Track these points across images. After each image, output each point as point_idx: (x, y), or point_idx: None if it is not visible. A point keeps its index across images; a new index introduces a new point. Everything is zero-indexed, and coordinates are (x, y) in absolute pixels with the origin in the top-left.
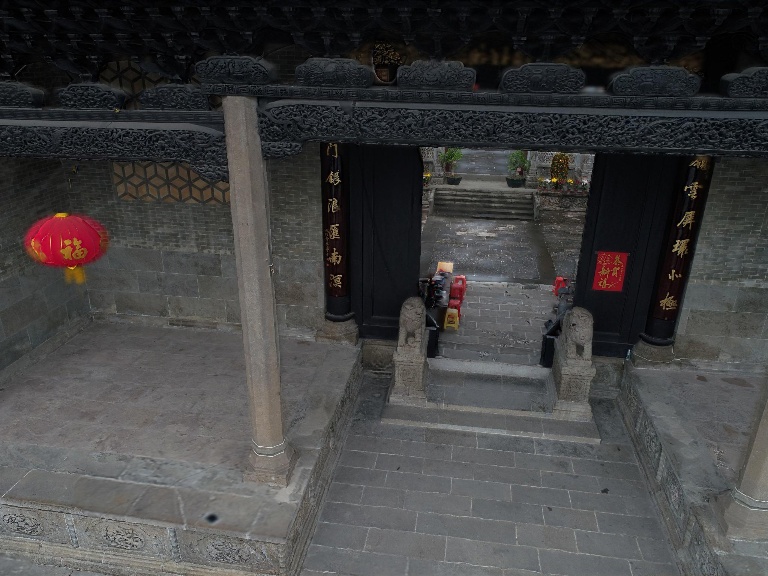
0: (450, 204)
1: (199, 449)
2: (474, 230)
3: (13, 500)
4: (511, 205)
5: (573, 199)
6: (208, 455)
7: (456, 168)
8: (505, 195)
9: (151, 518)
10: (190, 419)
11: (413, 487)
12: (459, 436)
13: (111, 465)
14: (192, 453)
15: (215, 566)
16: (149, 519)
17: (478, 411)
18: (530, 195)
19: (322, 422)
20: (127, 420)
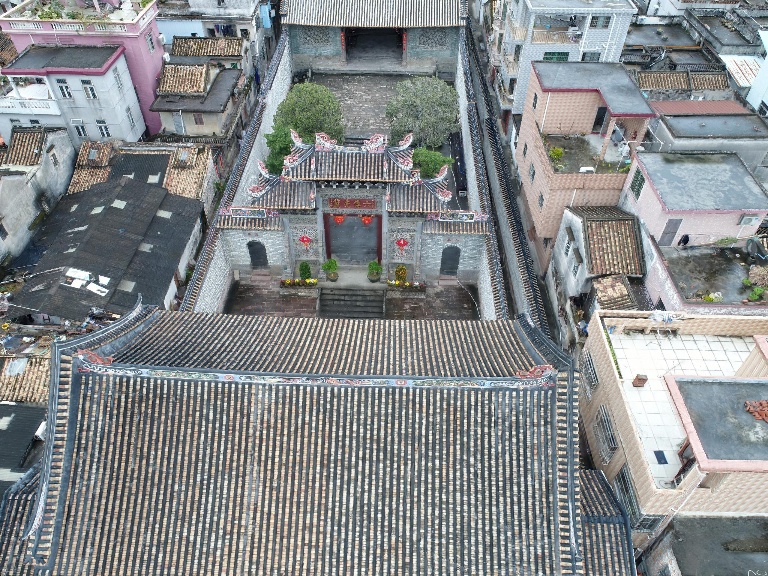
0: (330, 305)
1: None
2: None
3: None
4: (369, 303)
5: (410, 292)
6: None
7: (341, 225)
8: (366, 293)
9: None
10: None
11: None
12: None
13: None
14: None
15: None
16: None
17: None
18: (382, 292)
19: None
20: None
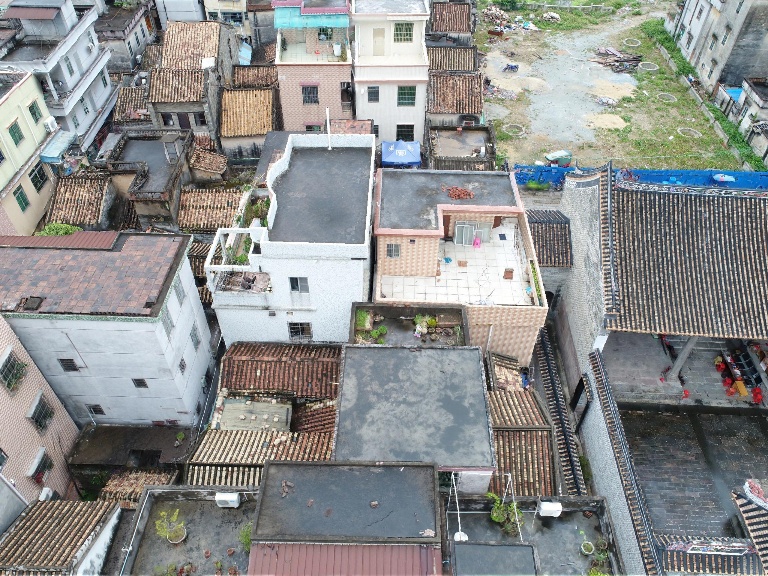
0: None
1: None
2: (767, 492)
3: None
4: None
5: None
6: None
7: None
8: None
9: None
10: None
11: None
12: None
13: None
14: None
15: None
16: None
17: None
18: None
19: None
20: None
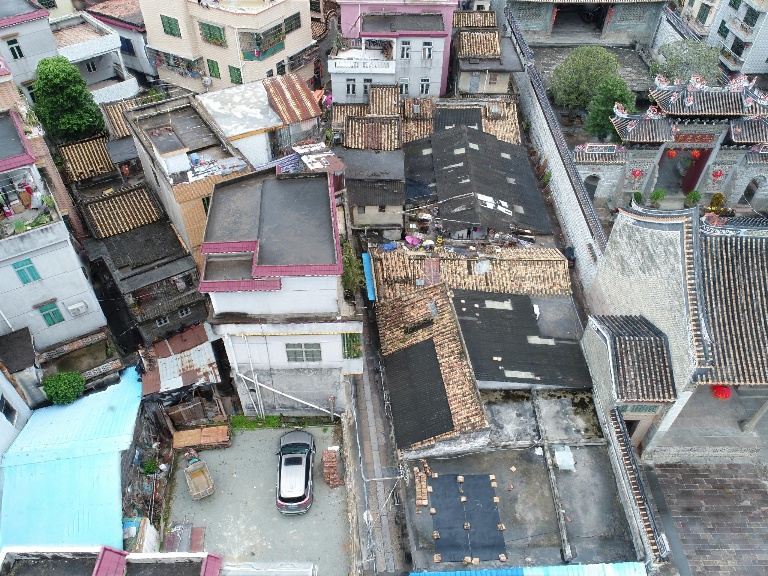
0: None
1: (722, 424)
2: None
3: (696, 446)
4: None
5: None
6: (726, 425)
7: None
8: None
9: (733, 446)
10: (709, 413)
11: (764, 421)
12: (764, 400)
13: (706, 432)
14: (722, 425)
15: (740, 452)
16: (733, 446)
17: (765, 389)
18: None
19: (743, 409)
20: (693, 416)
